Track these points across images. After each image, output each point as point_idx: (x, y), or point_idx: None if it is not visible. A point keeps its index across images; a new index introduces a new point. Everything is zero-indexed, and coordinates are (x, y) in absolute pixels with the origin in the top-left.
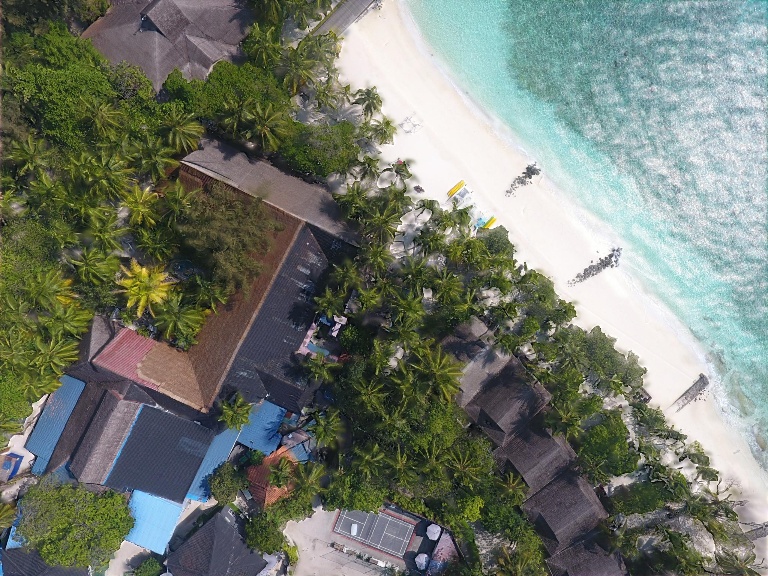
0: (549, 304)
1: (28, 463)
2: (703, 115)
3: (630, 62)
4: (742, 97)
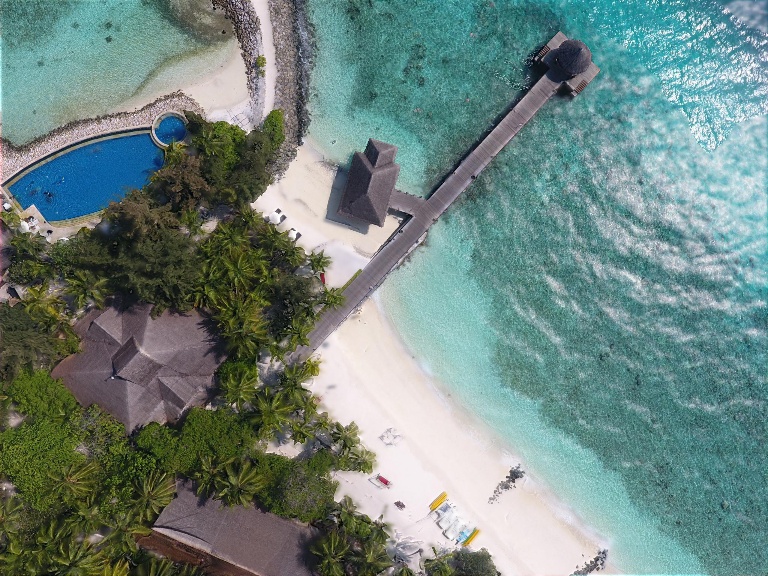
0: None
1: None
2: (690, 406)
3: (616, 355)
4: (730, 386)
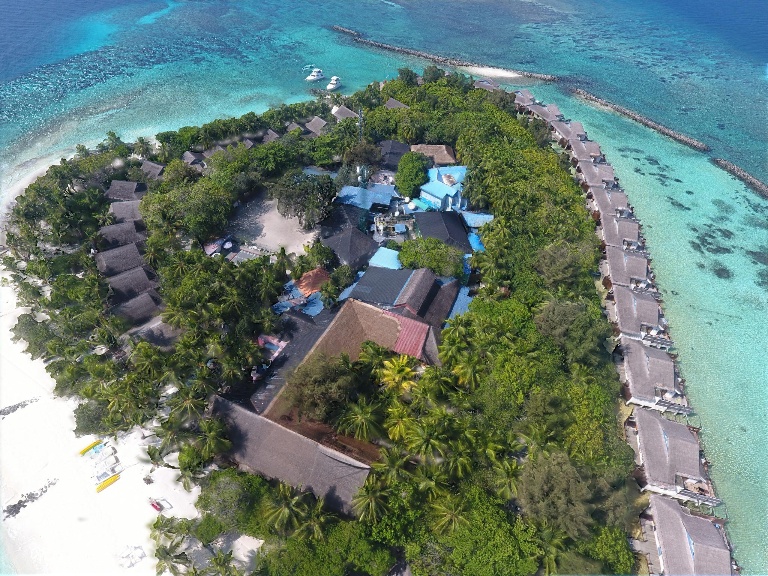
0: None
1: None
2: None
3: None
4: None
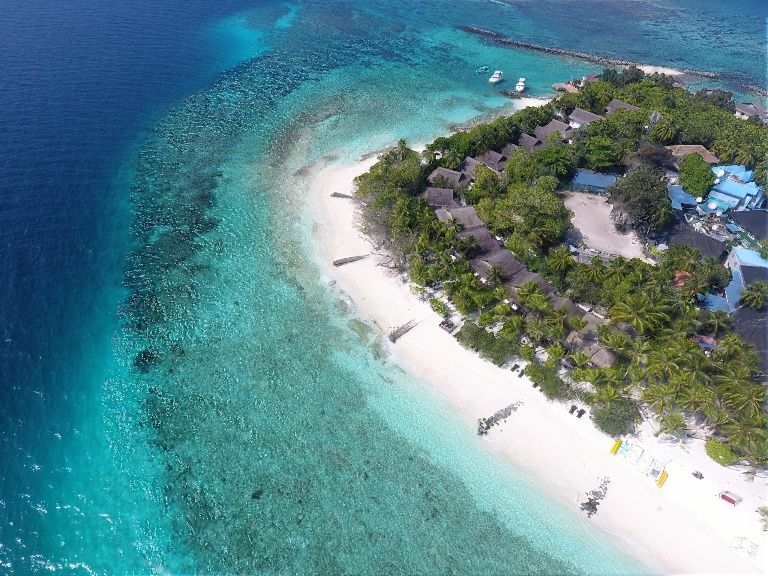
0: (573, 357)
1: None
2: None
3: None
4: None
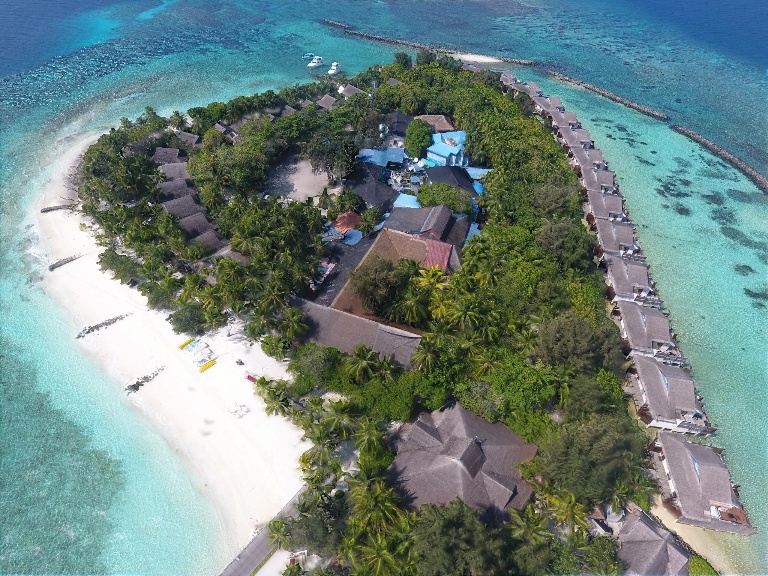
0: None
1: None
2: None
3: None
4: None
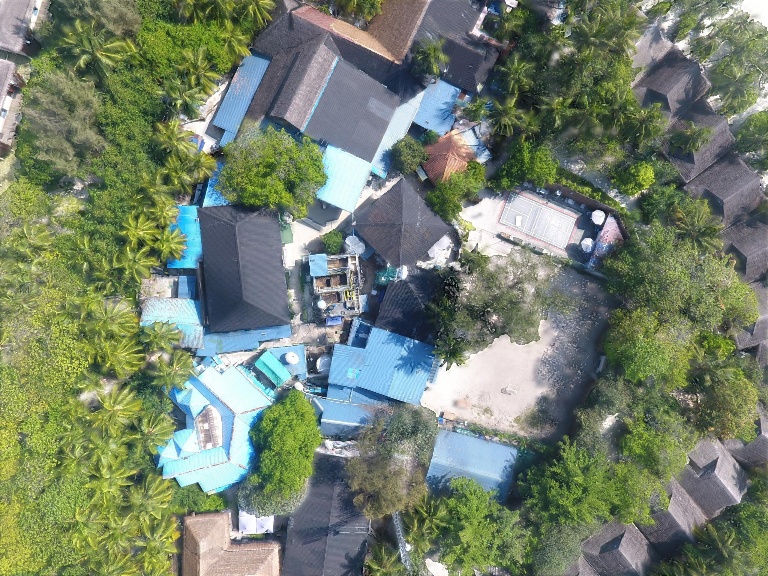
0: None
1: (209, 149)
2: None
3: None
4: None
